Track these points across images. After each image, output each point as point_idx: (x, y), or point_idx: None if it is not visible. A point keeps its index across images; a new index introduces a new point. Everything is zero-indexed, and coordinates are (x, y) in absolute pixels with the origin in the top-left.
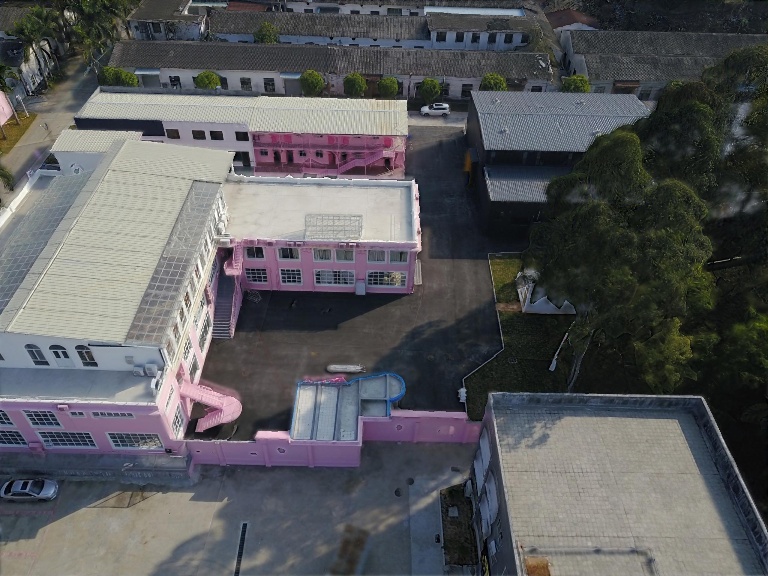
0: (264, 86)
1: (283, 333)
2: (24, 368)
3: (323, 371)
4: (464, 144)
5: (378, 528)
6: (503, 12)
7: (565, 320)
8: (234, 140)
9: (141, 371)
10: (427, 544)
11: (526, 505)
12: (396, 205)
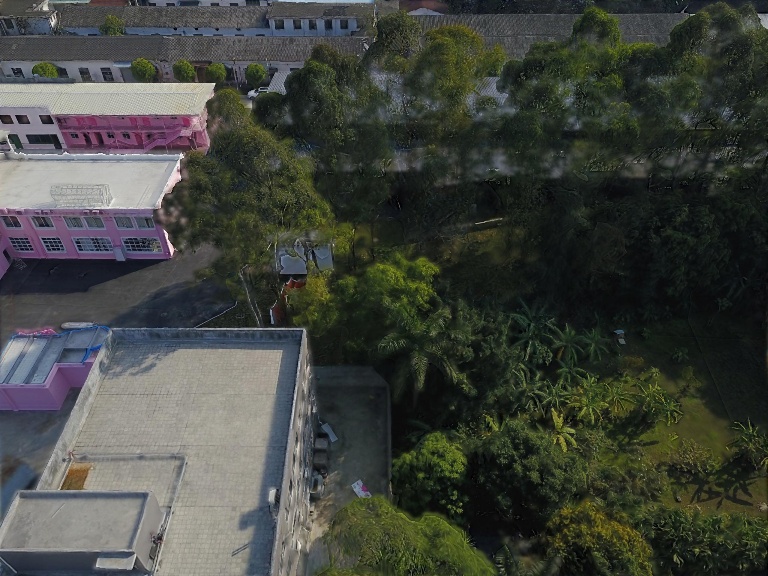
0: (102, 75)
1: (35, 296)
2: None
3: (58, 328)
4: None
5: None
6: (354, 0)
7: None
8: (40, 123)
9: None
10: None
11: (100, 421)
12: (157, 177)
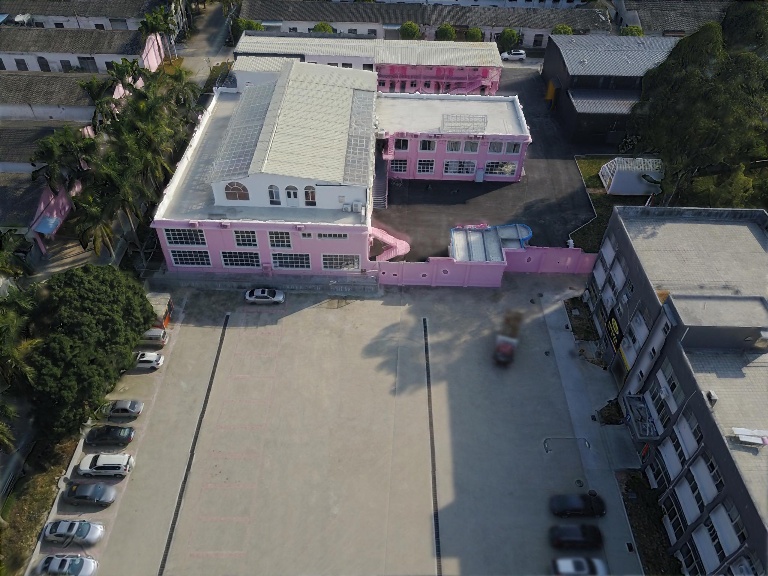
0: None
1: (425, 206)
2: (262, 207)
3: None
4: (541, 81)
5: (522, 321)
6: None
7: (641, 200)
8: None
9: (349, 207)
10: (560, 330)
11: (649, 266)
12: (505, 113)
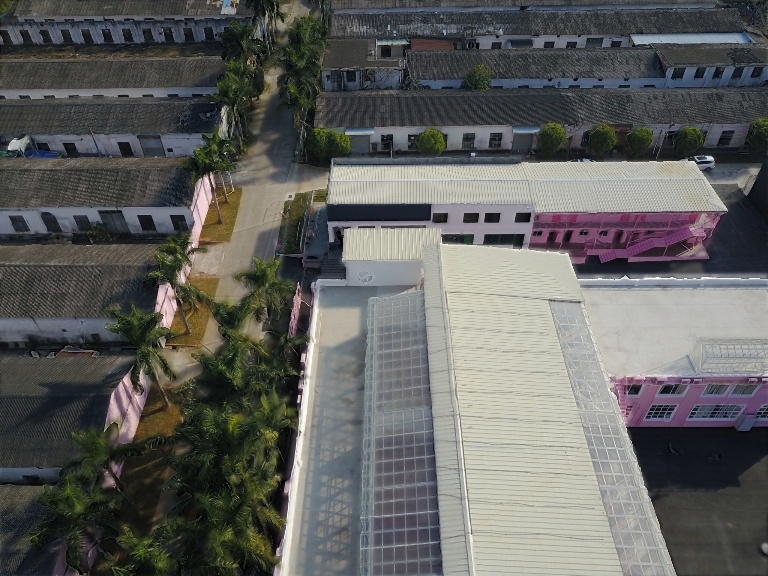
0: (489, 142)
1: (676, 493)
2: None
3: (758, 554)
4: (753, 208)
5: None
6: (723, 37)
7: None
8: (511, 222)
9: None
10: None
11: None
12: None
